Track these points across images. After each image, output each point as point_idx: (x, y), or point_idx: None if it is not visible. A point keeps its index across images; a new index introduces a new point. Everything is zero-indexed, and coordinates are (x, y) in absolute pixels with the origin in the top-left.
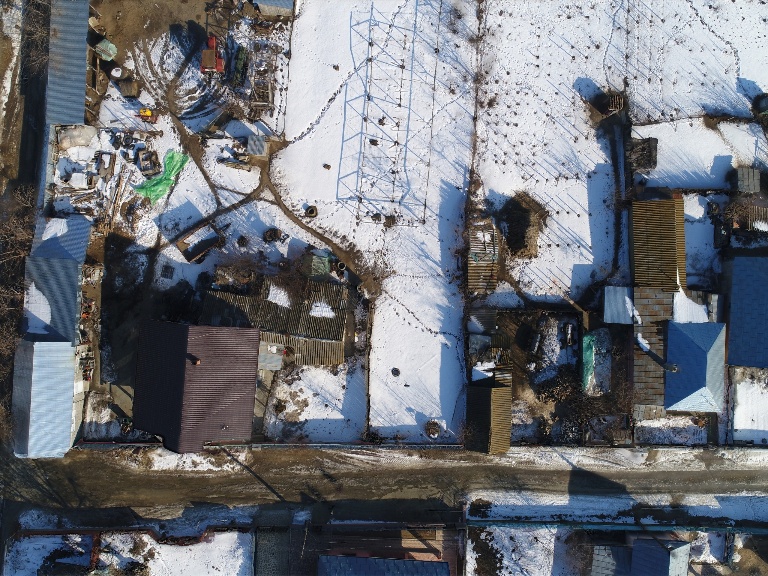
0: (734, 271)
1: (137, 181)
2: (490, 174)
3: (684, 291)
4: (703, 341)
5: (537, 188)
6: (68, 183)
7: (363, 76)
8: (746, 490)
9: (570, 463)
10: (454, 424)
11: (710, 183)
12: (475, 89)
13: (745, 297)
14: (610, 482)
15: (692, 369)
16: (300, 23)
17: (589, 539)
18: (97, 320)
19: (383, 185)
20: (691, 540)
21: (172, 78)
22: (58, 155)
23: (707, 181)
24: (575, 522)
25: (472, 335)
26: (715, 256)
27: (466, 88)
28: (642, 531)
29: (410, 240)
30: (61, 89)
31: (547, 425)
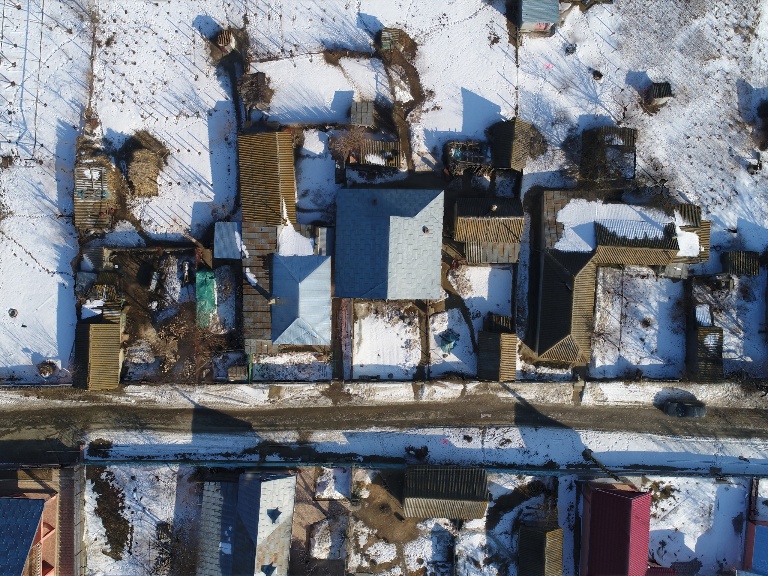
0: None
1: None
2: (107, 113)
3: (293, 225)
4: (300, 272)
5: (156, 126)
6: None
7: None
8: (375, 426)
9: (192, 401)
10: None
11: (331, 118)
12: (93, 28)
13: (345, 228)
14: (235, 420)
15: (289, 301)
16: None
17: (209, 477)
18: None
19: None
20: (317, 476)
21: None
22: None
23: (328, 116)
24: (198, 460)
25: (79, 273)
26: None
27: (83, 27)
28: (257, 467)
29: (27, 180)
30: None
31: (167, 363)
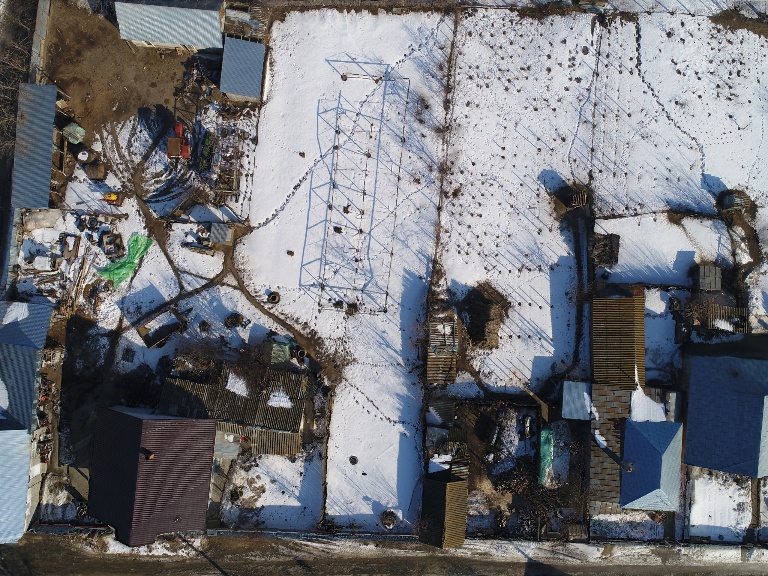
0: (692, 371)
1: (101, 263)
2: (453, 264)
3: (642, 388)
4: (659, 442)
5: (500, 279)
6: (32, 264)
7: (329, 164)
8: None
9: (526, 555)
10: (410, 514)
11: (672, 278)
12: (440, 179)
13: (702, 398)
14: (565, 575)
15: (647, 469)
16: (268, 110)
17: None
18: (57, 402)
19: (346, 273)
20: None
21: (139, 161)
22: (23, 236)
23: (669, 276)
24: None
25: (430, 427)
26: (676, 351)
27: (431, 178)
28: None
29: (371, 328)
30: (27, 173)
31: (503, 517)
